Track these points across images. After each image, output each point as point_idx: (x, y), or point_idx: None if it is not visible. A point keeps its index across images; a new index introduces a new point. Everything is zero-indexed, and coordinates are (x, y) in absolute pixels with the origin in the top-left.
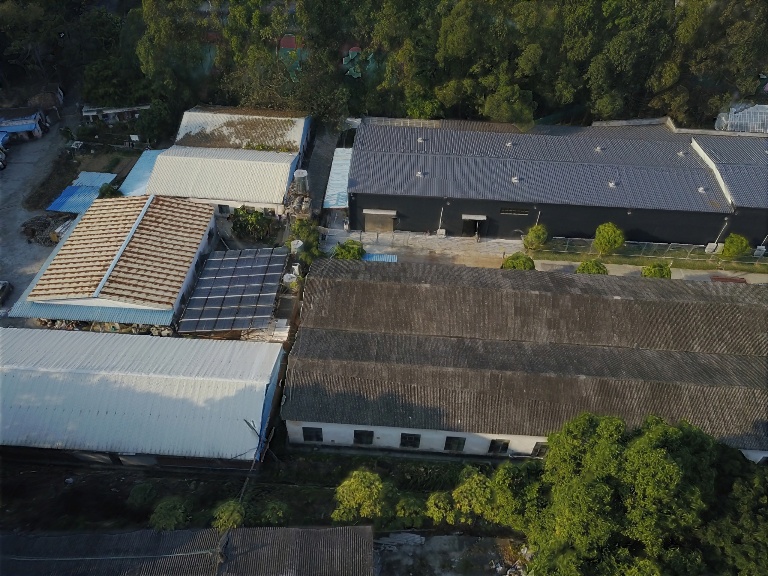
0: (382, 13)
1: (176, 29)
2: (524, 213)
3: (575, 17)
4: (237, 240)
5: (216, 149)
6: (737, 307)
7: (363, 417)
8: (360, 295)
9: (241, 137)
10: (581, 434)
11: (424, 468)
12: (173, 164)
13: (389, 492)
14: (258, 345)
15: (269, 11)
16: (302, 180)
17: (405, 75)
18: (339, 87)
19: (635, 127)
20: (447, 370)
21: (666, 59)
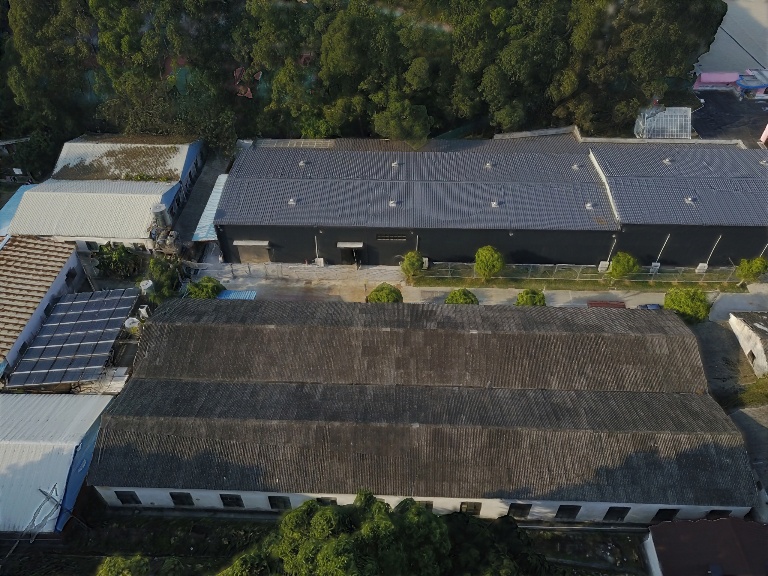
0: (260, 32)
1: (48, 58)
2: (402, 238)
3: (462, 27)
4: (104, 278)
5: (92, 181)
6: (602, 337)
7: (174, 479)
8: (199, 340)
9: (121, 167)
10: (294, 528)
11: (244, 531)
12: (39, 200)
13: (170, 571)
14: (86, 399)
15: (141, 36)
16: (160, 215)
17: (292, 95)
18: (225, 110)
19: (540, 138)
20: (270, 423)
21: (564, 66)
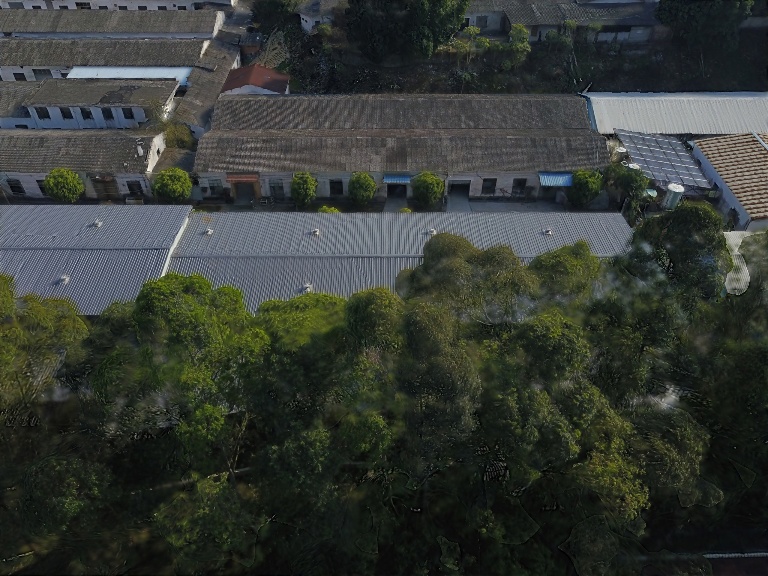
0: None
1: None
2: None
3: None
4: None
5: None
6: None
7: (528, 94)
8: None
9: None
10: None
11: None
12: None
13: None
14: None
15: None
16: None
17: None
18: None
19: None
20: None
21: None
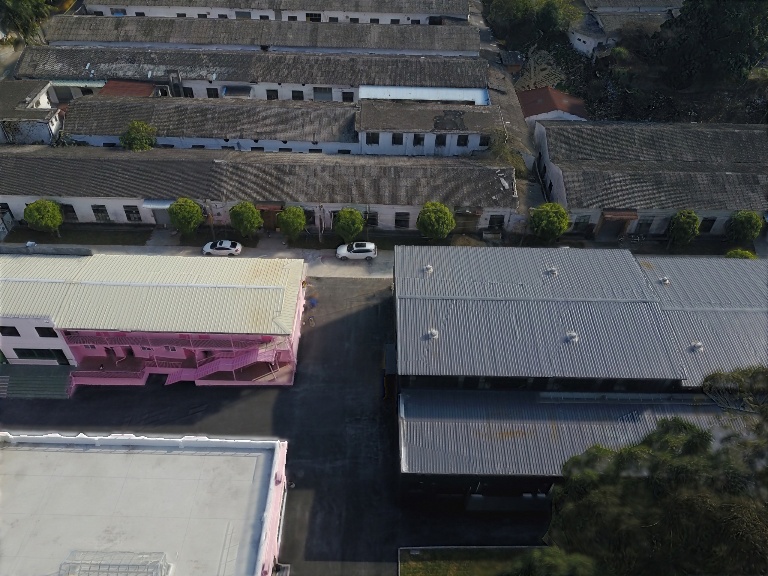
0: None
1: None
2: None
3: None
4: None
5: None
6: None
7: None
8: None
9: None
10: None
11: None
12: None
13: None
14: None
15: None
16: None
17: None
18: None
19: None
20: None
21: None
